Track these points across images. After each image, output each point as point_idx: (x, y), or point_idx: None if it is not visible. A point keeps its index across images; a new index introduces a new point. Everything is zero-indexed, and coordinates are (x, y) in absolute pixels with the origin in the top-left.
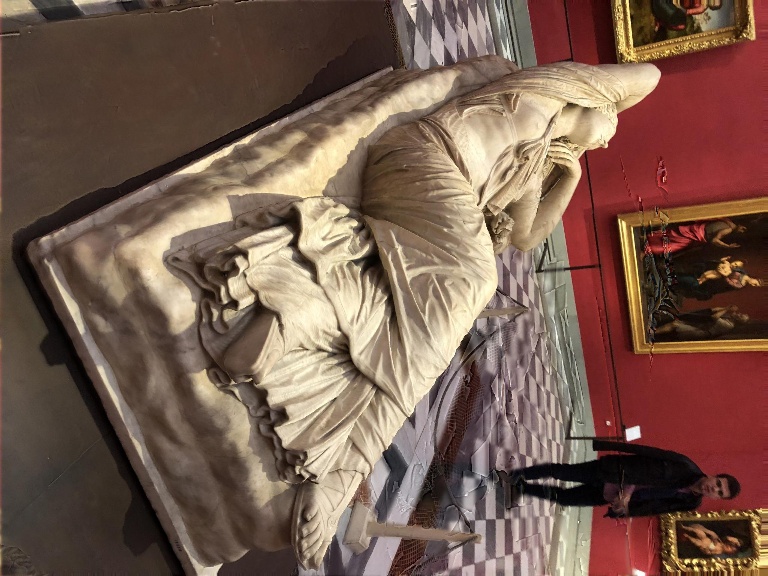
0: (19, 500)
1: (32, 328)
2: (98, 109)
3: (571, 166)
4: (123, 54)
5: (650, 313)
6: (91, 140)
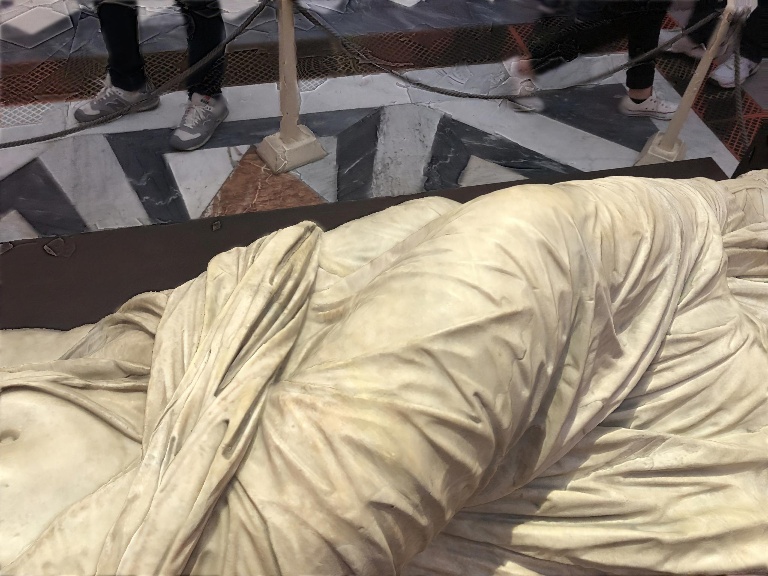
0: None
1: None
2: None
3: None
4: None
5: None
6: None
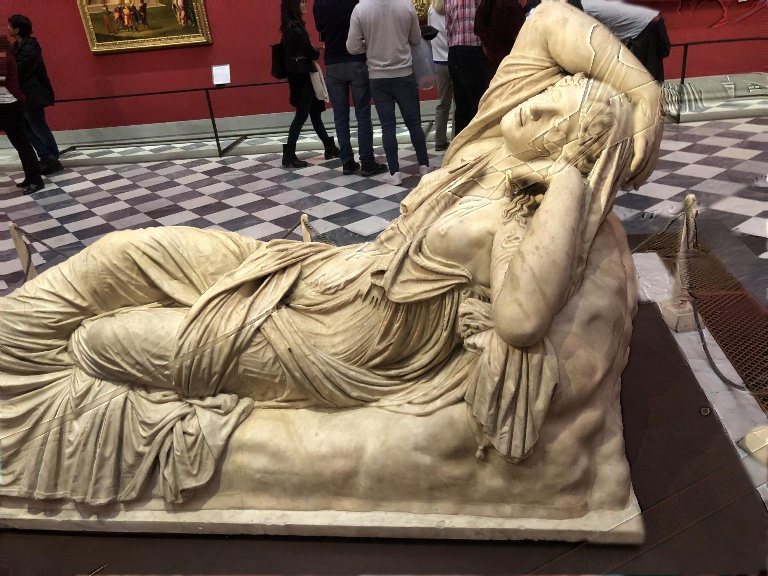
0: None
1: None
2: None
3: None
4: None
5: (580, 144)
6: None
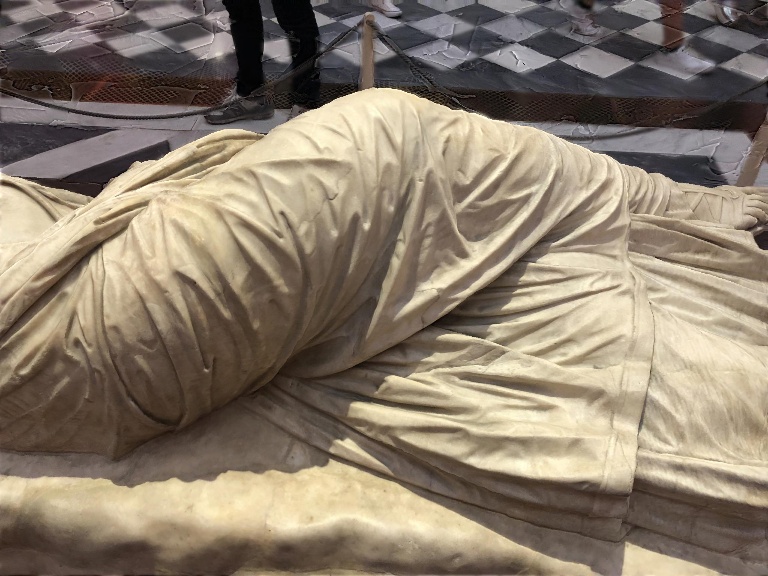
0: None
1: None
2: None
3: None
4: None
5: None
6: None
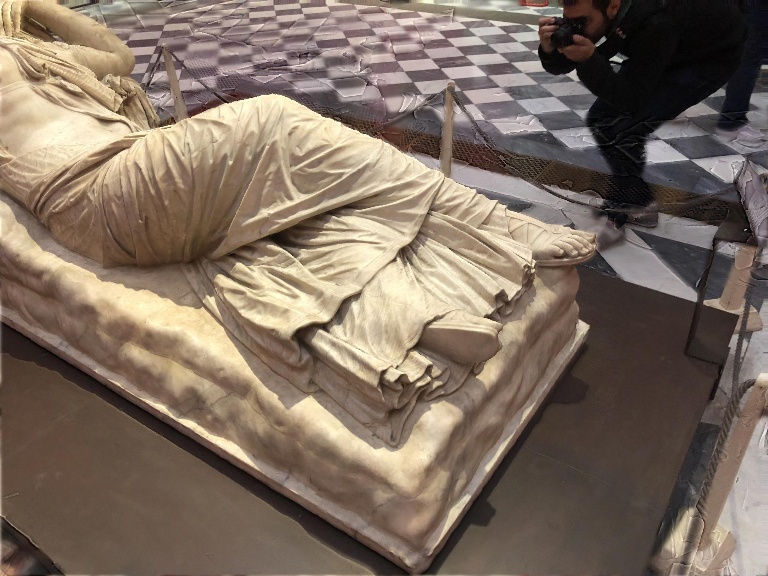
0: (604, 491)
1: (476, 539)
2: (225, 574)
3: (19, 5)
4: (139, 575)
5: None
6: (265, 566)
